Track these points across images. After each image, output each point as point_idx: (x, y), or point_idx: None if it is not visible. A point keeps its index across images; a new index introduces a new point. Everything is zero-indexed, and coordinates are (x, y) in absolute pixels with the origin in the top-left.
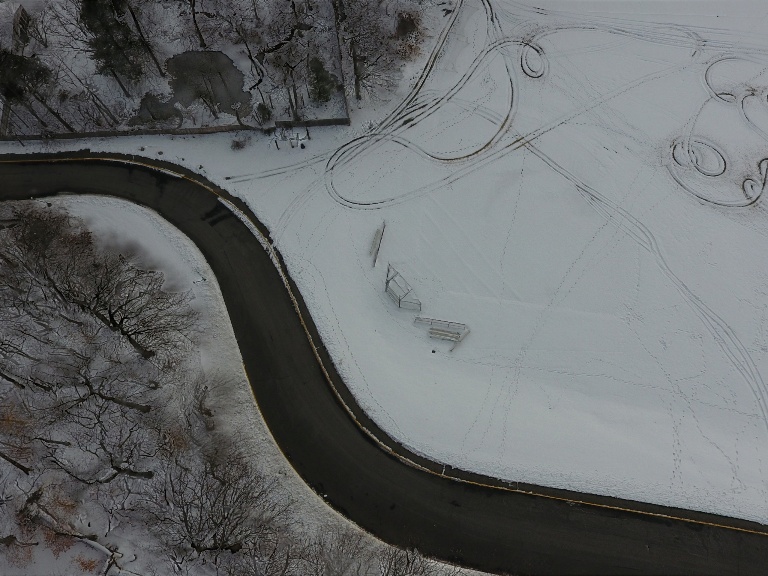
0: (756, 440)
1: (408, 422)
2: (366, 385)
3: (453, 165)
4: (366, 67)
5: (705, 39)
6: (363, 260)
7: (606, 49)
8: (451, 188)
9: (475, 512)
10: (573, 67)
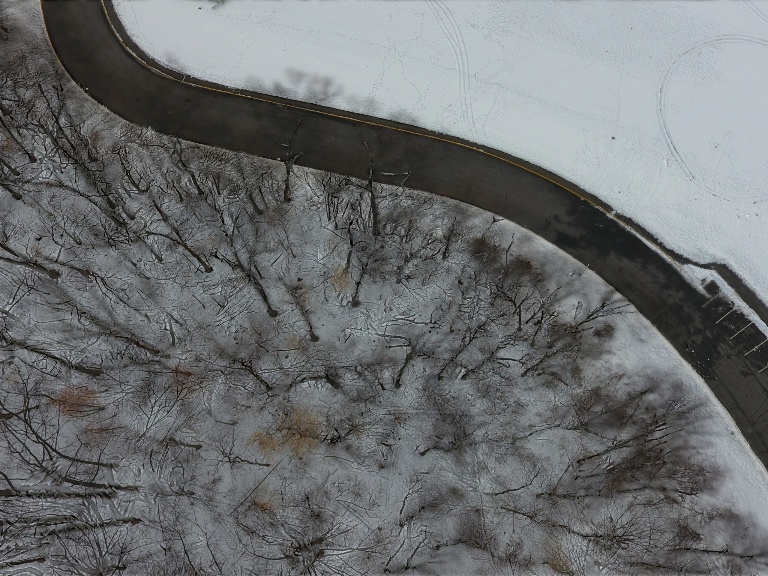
0: (448, 84)
1: (163, 46)
2: (136, 21)
3: None
4: None
5: None
6: None
7: None
8: None
9: (203, 107)
10: None
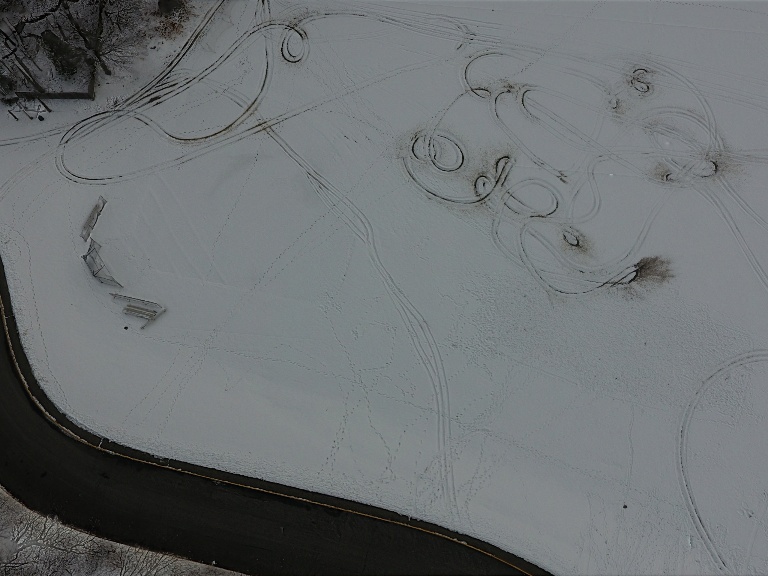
0: (424, 433)
1: (78, 394)
2: (46, 356)
3: (189, 145)
4: (102, 42)
5: (474, 32)
6: (76, 234)
7: (371, 37)
8: (182, 168)
9: (122, 485)
10: (333, 54)
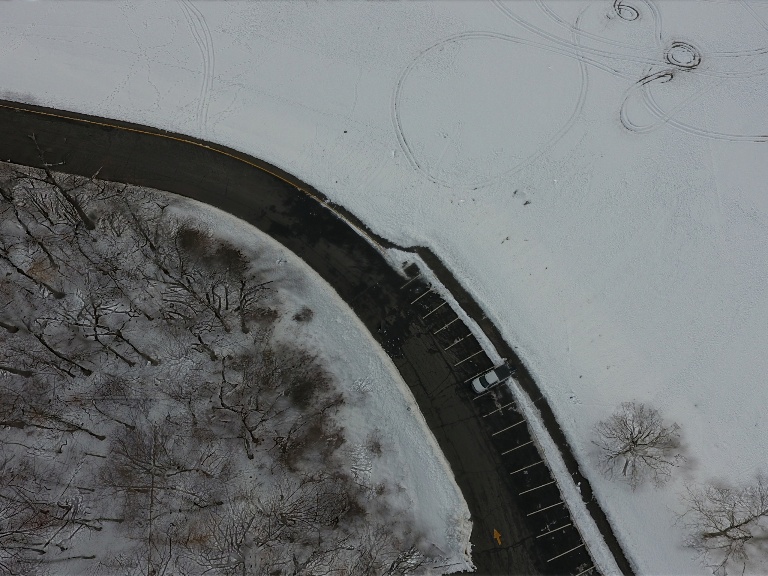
0: (190, 86)
1: None
2: None
3: None
4: None
5: None
6: None
7: None
8: None
9: None
10: None
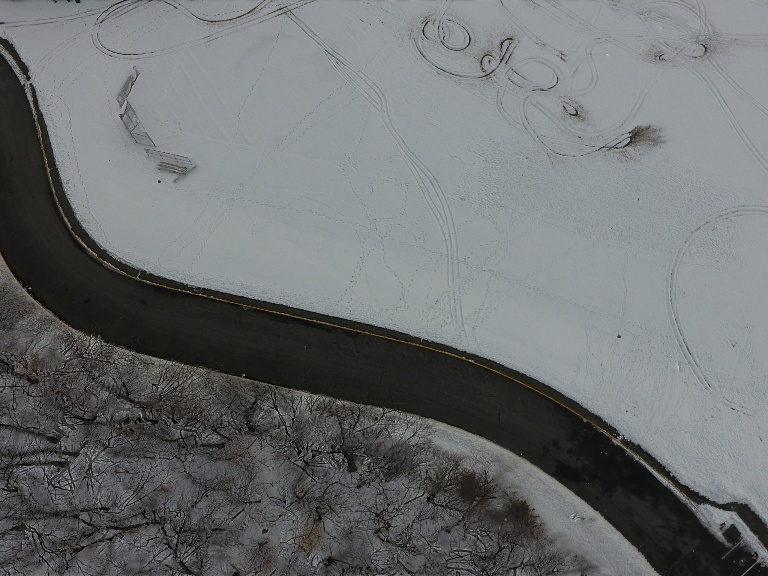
0: (434, 273)
1: (117, 234)
2: (87, 202)
3: (215, 26)
4: None
5: None
6: (112, 101)
7: None
8: (209, 46)
9: (159, 310)
10: None
